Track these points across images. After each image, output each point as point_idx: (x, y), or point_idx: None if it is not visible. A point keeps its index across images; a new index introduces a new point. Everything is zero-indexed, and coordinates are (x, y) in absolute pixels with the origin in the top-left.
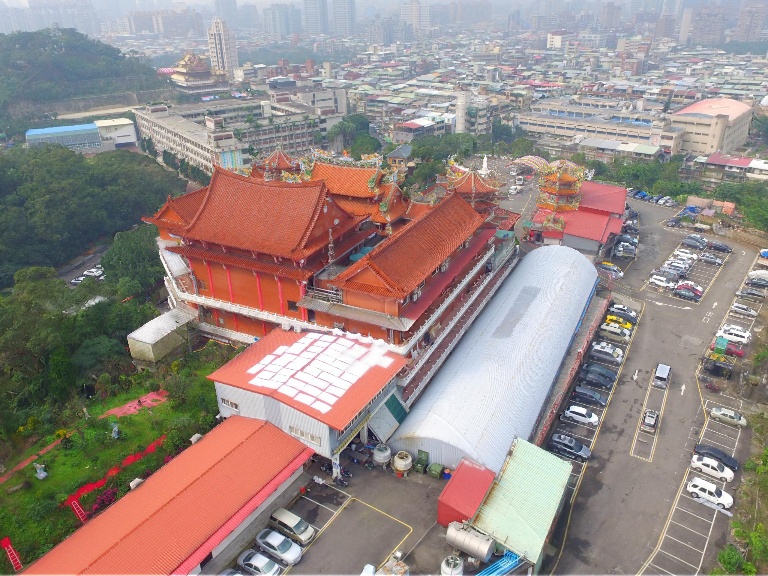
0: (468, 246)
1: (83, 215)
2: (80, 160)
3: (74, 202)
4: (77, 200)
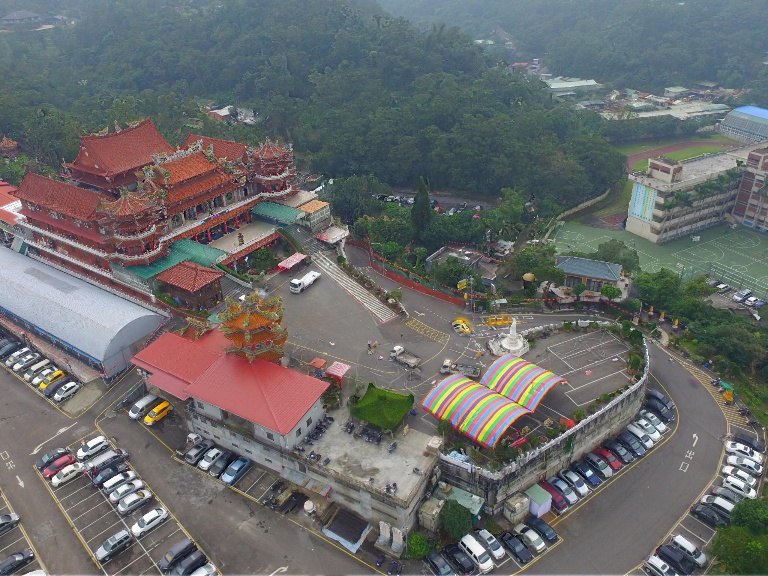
0: (85, 229)
1: (440, 163)
2: (535, 131)
3: (436, 151)
4: (438, 150)
